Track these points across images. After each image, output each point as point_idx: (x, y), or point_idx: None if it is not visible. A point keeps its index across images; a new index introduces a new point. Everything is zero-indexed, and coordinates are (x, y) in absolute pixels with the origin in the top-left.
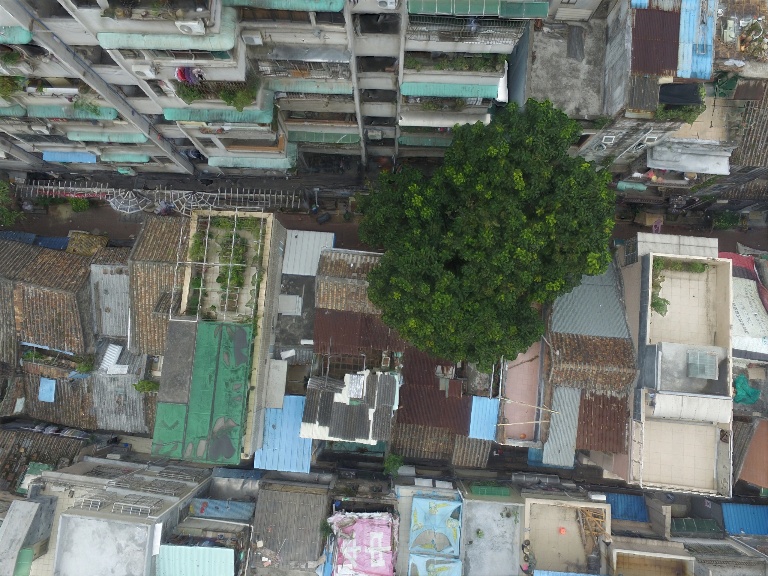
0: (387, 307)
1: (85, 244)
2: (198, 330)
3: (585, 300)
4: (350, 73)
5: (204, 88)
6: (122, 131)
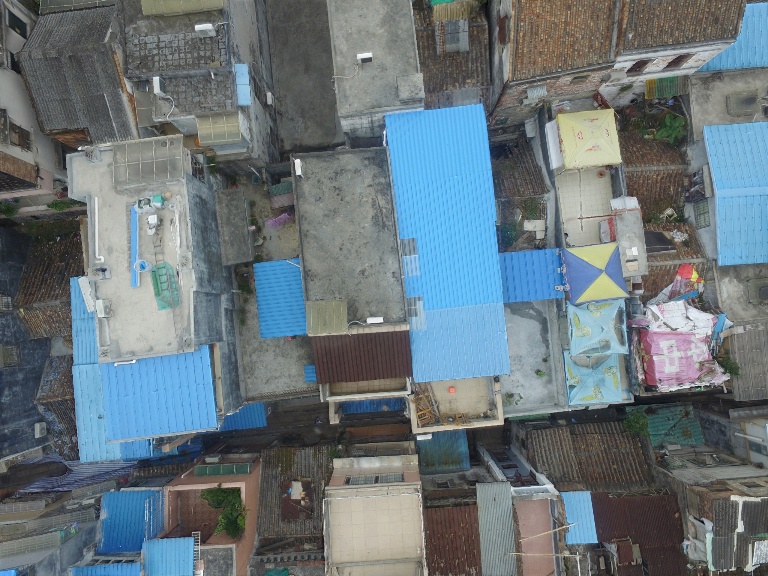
0: None
1: None
2: None
3: None
4: None
5: None
6: None
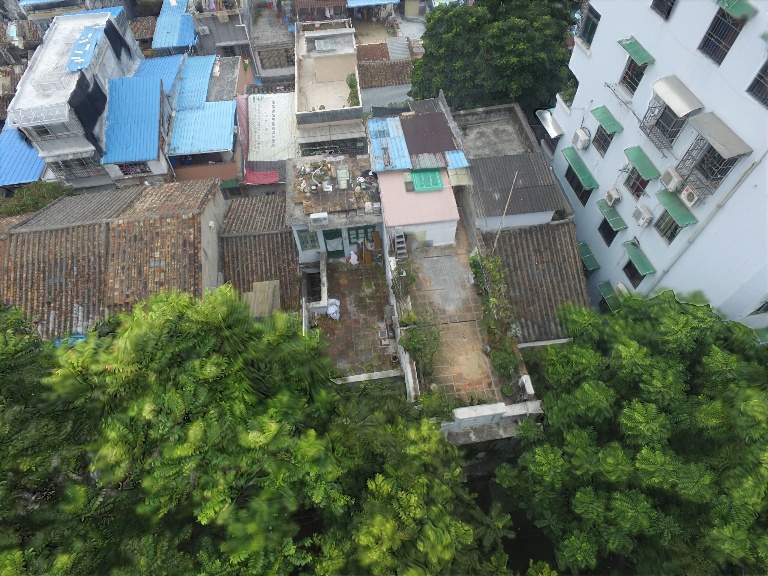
0: None
1: None
2: None
3: None
4: None
5: None
6: None
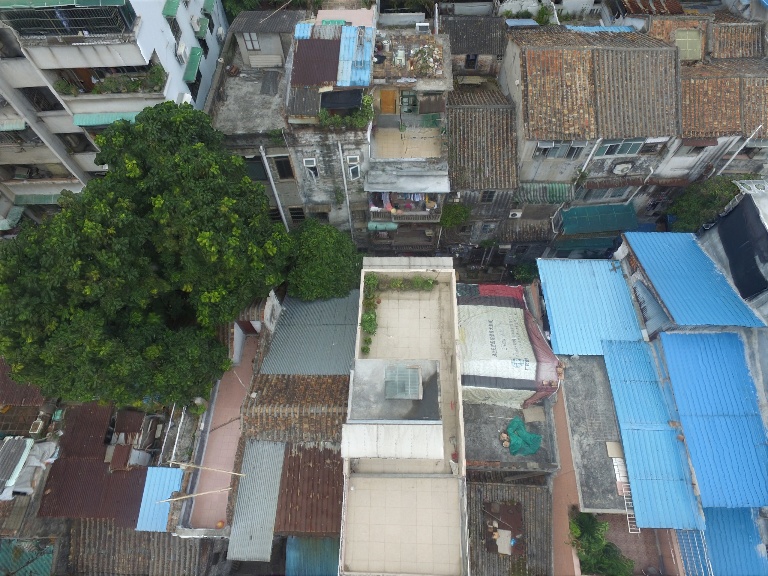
0: None
1: None
2: None
3: (317, 340)
4: (4, 101)
5: None
6: None
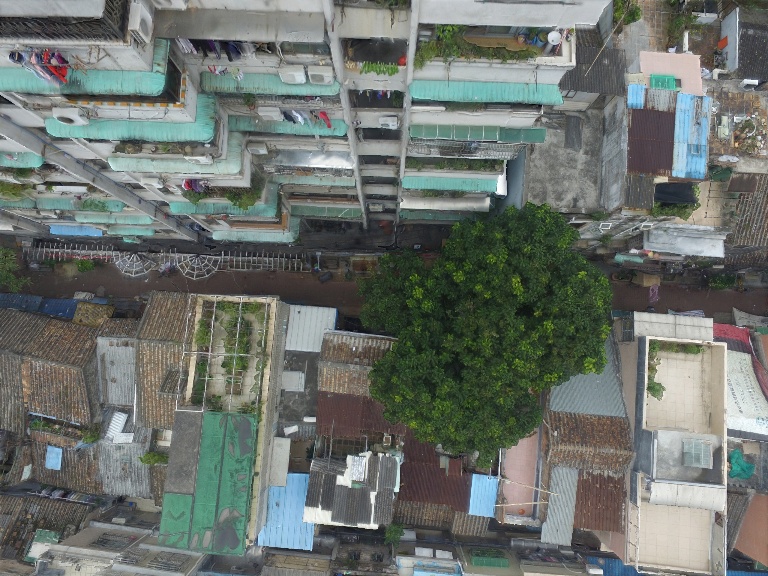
0: (389, 404)
1: (91, 314)
2: (204, 420)
3: (583, 375)
4: (353, 172)
5: (210, 190)
6: (129, 214)
